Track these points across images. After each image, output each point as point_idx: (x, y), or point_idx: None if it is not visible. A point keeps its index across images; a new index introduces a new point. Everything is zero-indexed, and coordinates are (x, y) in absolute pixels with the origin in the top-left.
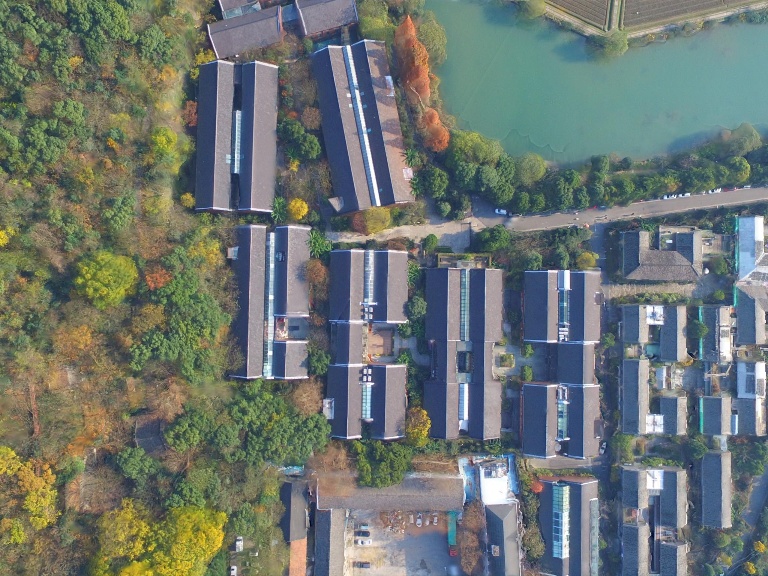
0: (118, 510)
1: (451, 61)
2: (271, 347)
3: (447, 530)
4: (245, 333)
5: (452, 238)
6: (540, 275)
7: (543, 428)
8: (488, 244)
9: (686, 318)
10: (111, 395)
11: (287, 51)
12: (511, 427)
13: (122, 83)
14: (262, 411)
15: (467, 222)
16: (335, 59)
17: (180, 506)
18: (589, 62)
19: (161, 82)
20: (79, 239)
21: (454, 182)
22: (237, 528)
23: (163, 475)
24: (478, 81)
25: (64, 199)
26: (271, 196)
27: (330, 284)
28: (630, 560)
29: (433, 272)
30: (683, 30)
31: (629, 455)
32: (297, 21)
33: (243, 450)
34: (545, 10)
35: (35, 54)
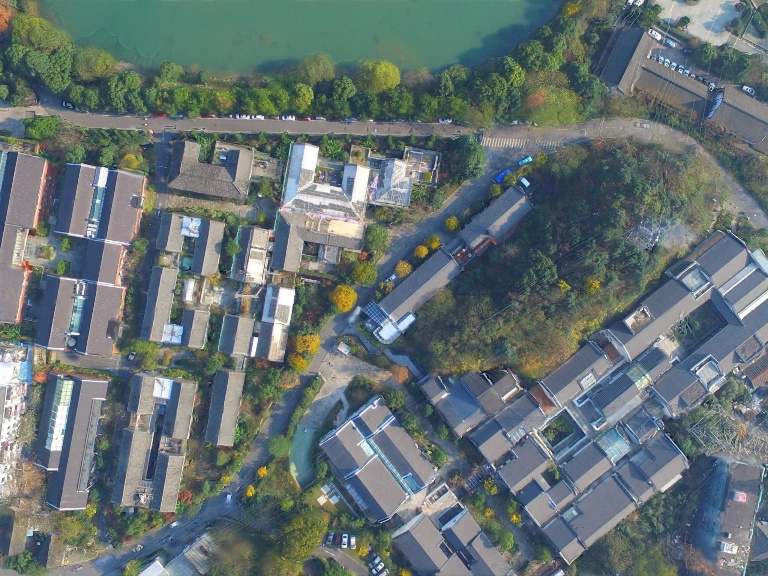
0: None
1: None
2: None
3: None
4: None
5: (15, 124)
6: (75, 168)
7: (50, 319)
8: (27, 129)
9: (223, 235)
10: None
11: None
12: None
13: None
14: None
15: (33, 110)
16: None
17: None
18: None
19: None
20: None
21: (8, 63)
22: None
23: None
24: None
25: None
26: None
27: None
28: (123, 463)
29: None
30: None
31: (148, 362)
32: None
33: None
34: None
35: None
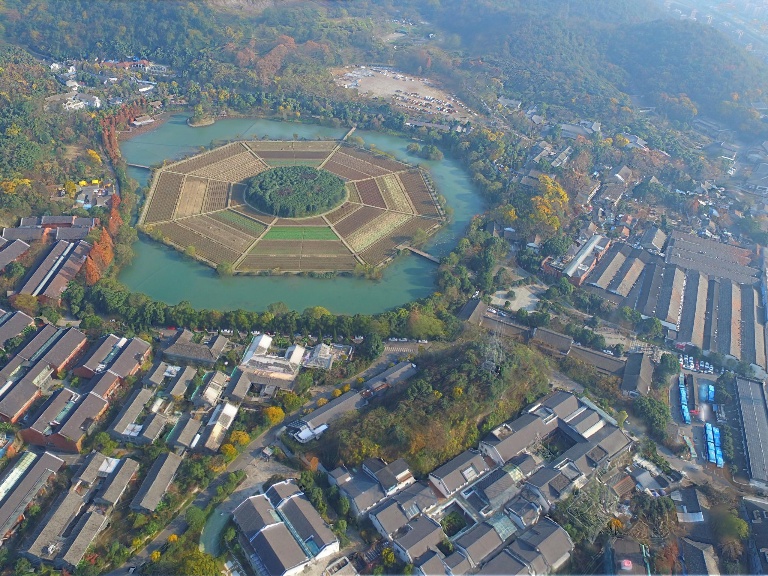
0: None
1: (134, 268)
2: None
3: None
4: None
5: None
6: None
7: None
8: None
9: (193, 377)
10: None
11: None
12: None
13: None
14: None
15: None
16: (61, 245)
17: None
18: (212, 278)
19: None
20: None
21: (87, 295)
22: None
23: None
24: (146, 279)
25: None
26: None
27: None
28: (47, 518)
29: None
30: None
31: (103, 453)
32: None
33: None
34: (193, 252)
35: None
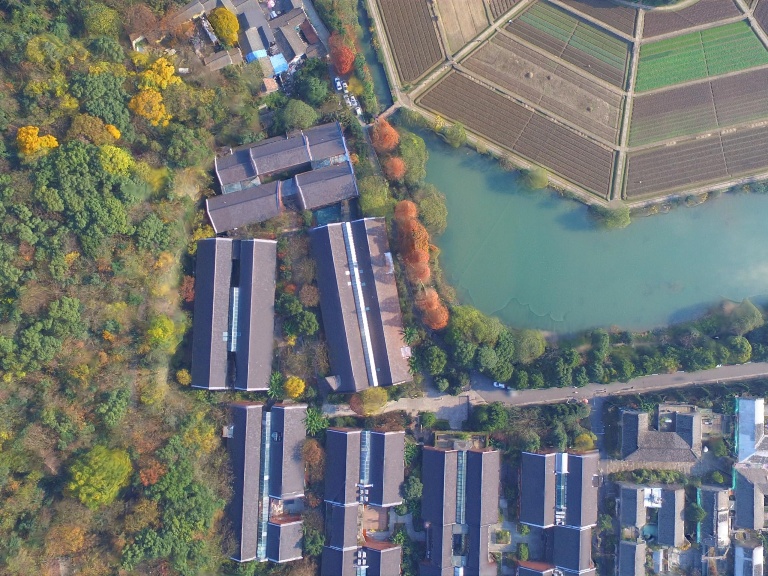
0: None
1: (452, 228)
2: (265, 528)
3: None
4: (239, 516)
5: (450, 411)
6: (538, 458)
7: None
8: (486, 427)
9: (684, 500)
10: None
11: (286, 222)
12: None
13: (119, 273)
14: None
15: (465, 395)
16: (334, 237)
17: None
18: (591, 231)
19: (158, 268)
20: (73, 434)
21: (452, 361)
22: None
23: None
24: (478, 247)
25: (58, 394)
26: (268, 373)
27: (326, 465)
28: None
29: (430, 453)
30: (686, 202)
31: None
32: (297, 195)
33: None
34: (547, 183)
35: (31, 254)
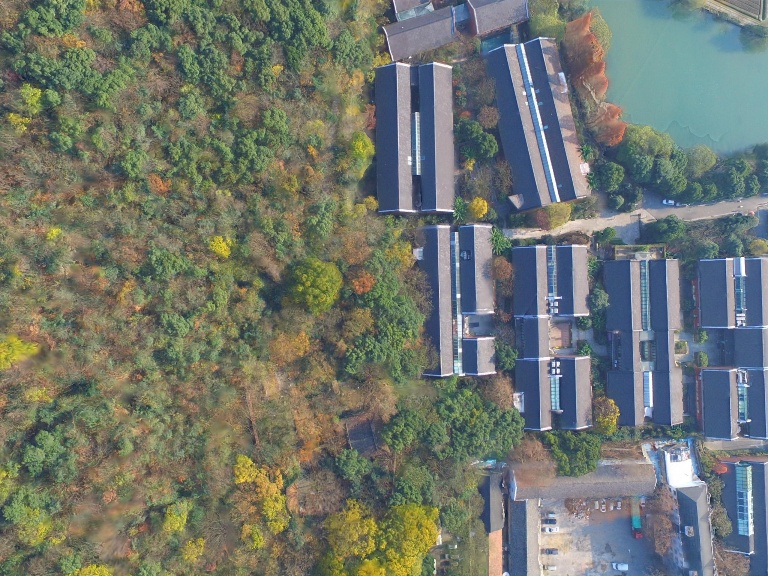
0: (346, 511)
1: (611, 55)
2: (460, 345)
3: (631, 514)
4: (437, 332)
5: (622, 230)
6: (717, 263)
7: (727, 411)
8: (667, 235)
9: None
10: (316, 399)
11: (457, 51)
12: (688, 412)
13: (317, 90)
14: (464, 408)
15: (636, 214)
16: (511, 58)
17: (402, 504)
18: (745, 52)
19: (351, 87)
20: (286, 247)
21: (629, 175)
22: (447, 522)
23: (376, 475)
24: (636, 74)
25: (270, 208)
26: (452, 196)
27: (515, 280)
28: None
29: (613, 264)
30: None
31: None
32: (469, 21)
33: (451, 447)
34: None
35: (241, 64)
